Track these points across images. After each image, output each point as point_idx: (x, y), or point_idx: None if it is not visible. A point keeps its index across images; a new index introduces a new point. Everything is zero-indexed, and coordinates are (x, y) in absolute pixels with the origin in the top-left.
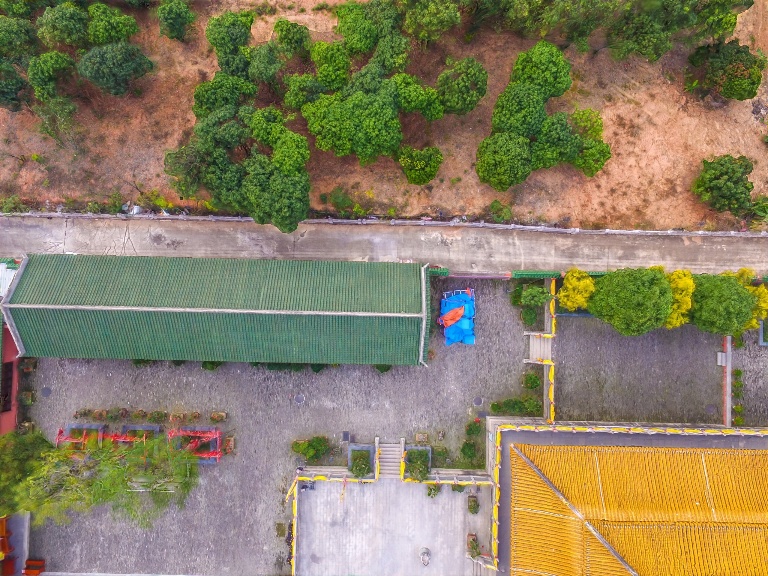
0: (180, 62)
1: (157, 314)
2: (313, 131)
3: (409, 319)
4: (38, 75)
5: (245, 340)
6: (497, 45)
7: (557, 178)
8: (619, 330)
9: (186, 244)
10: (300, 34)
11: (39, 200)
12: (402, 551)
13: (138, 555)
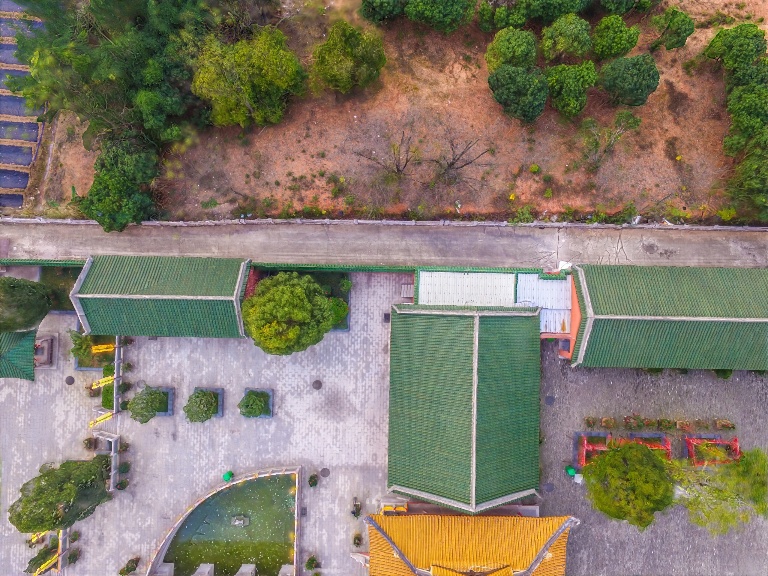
0: None
1: (734, 324)
2: None
3: None
4: (577, 87)
5: None
6: None
7: None
8: None
9: (679, 253)
10: None
11: (538, 210)
12: None
13: (644, 561)
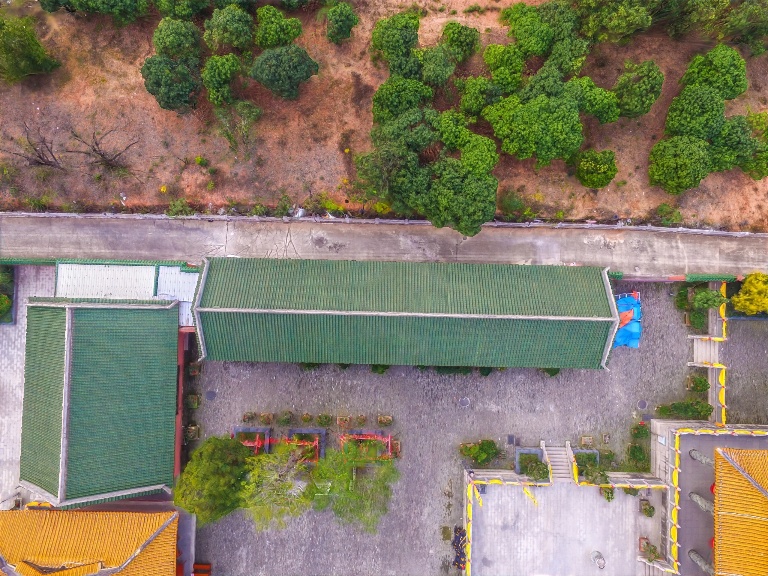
0: (333, 64)
1: (347, 318)
2: (501, 134)
3: (599, 323)
4: (214, 78)
5: (429, 344)
6: (651, 48)
7: (717, 181)
8: None
9: (348, 247)
10: (472, 37)
11: (202, 203)
12: (573, 554)
13: (304, 559)
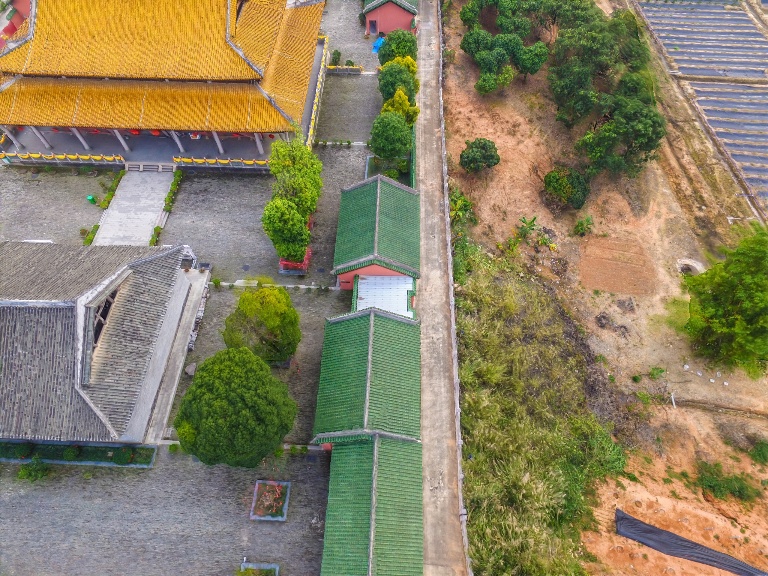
0: None
1: None
2: None
3: None
4: None
5: None
6: None
7: (473, 88)
8: None
9: None
10: None
11: None
12: None
13: None
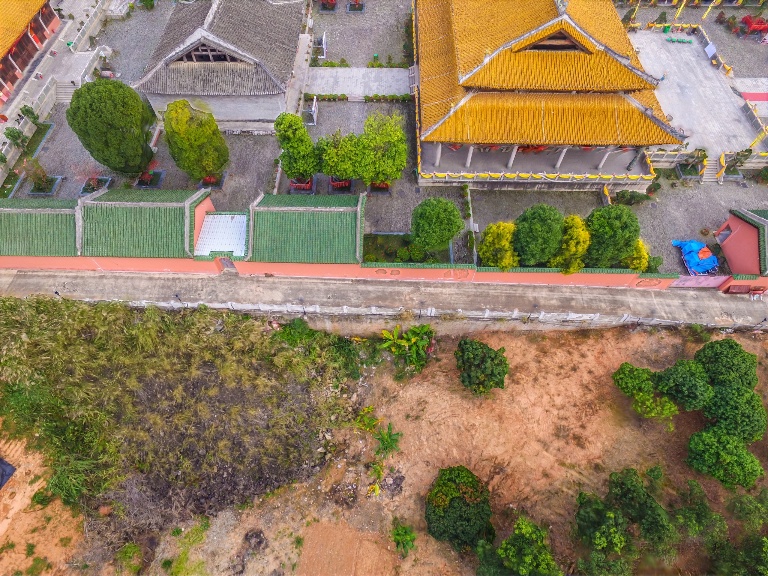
0: None
1: None
2: None
3: None
4: None
5: None
6: None
7: None
8: None
9: None
10: None
11: None
12: (681, 124)
13: None
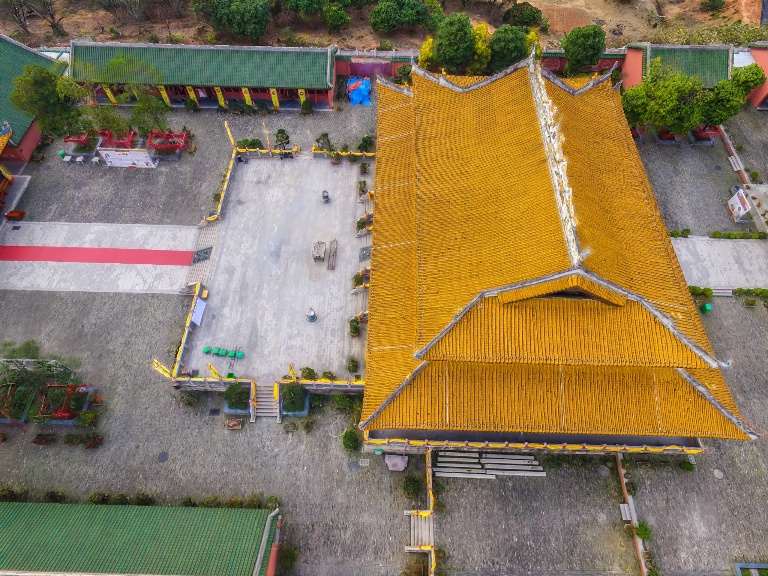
0: None
1: (165, 50)
2: None
3: (321, 54)
4: None
5: (216, 69)
6: None
7: (423, 43)
8: (447, 49)
9: None
10: None
11: None
12: (308, 199)
13: (101, 211)
